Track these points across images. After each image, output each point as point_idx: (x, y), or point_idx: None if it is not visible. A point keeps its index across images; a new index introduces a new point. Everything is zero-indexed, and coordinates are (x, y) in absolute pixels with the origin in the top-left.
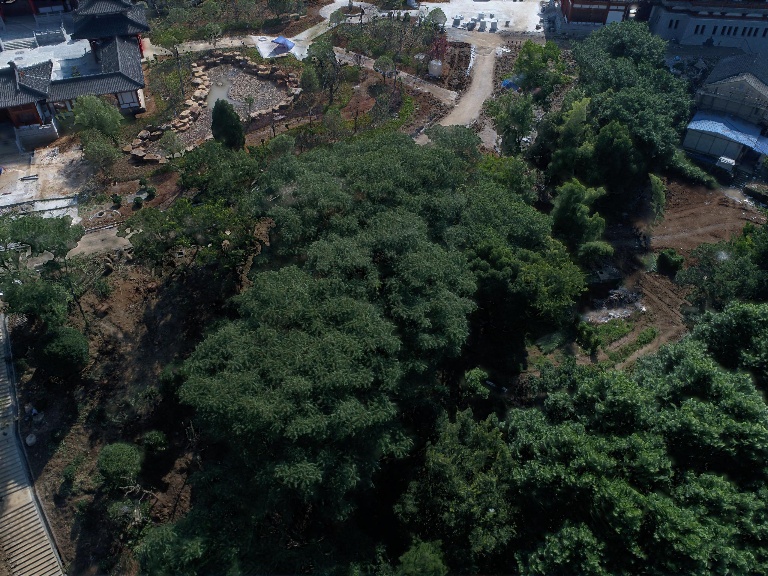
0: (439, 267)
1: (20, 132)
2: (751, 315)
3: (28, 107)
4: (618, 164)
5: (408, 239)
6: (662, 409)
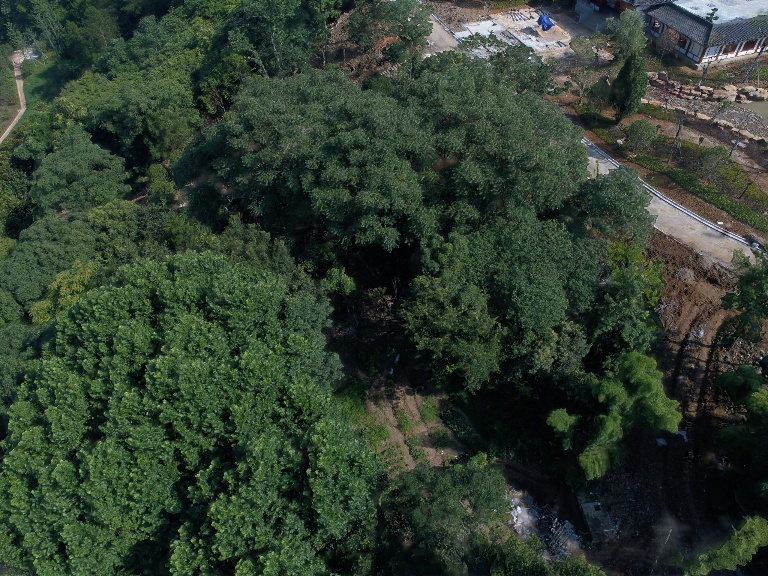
0: (359, 156)
1: (611, 22)
2: (312, 432)
3: (630, 7)
4: (755, 454)
5: (372, 122)
6: (221, 330)
